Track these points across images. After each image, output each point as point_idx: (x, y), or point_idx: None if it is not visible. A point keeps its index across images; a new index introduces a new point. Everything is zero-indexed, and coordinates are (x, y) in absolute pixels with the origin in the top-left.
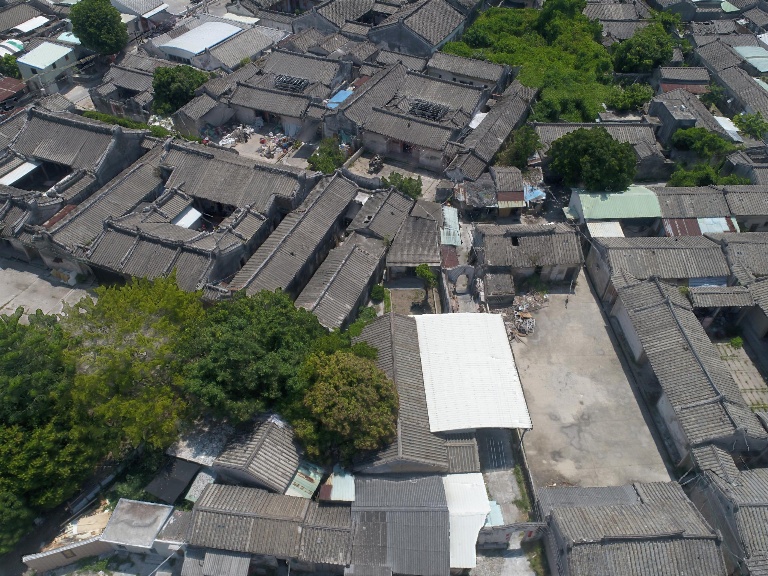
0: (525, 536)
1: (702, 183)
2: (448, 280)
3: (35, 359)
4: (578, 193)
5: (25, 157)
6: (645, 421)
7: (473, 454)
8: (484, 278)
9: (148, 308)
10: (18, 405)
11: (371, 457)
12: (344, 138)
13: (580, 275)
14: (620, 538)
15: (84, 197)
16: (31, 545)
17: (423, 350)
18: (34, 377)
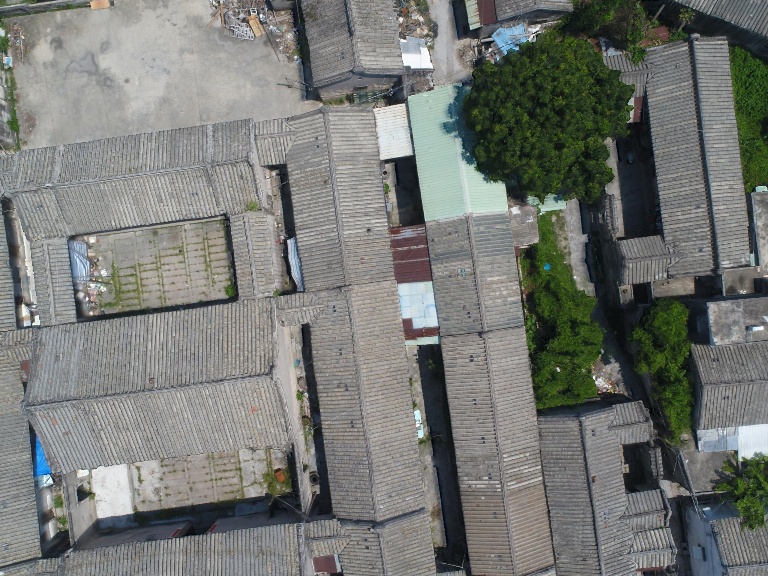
0: None
1: (554, 332)
2: None
3: None
4: None
5: None
6: None
7: None
8: None
9: None
10: None
11: None
12: None
13: None
14: None
15: None
16: None
17: None
18: None
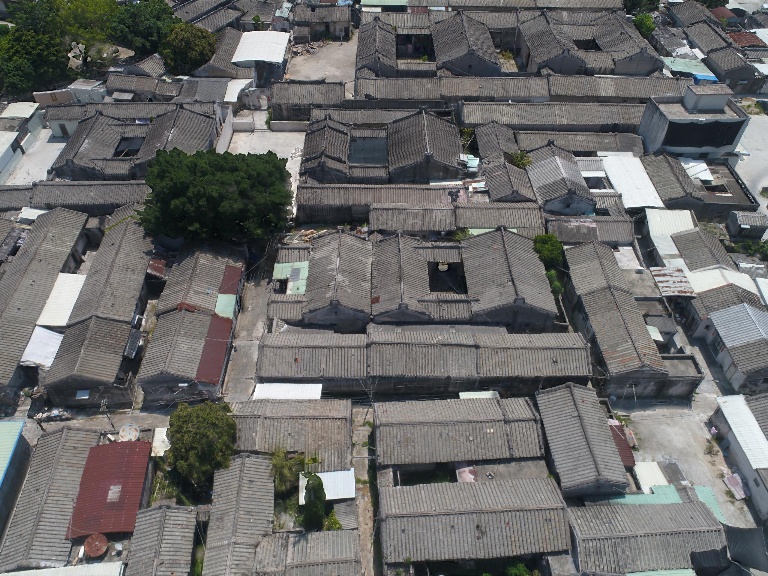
0: None
1: None
2: (274, 30)
3: (41, 4)
4: None
5: None
6: None
7: (250, 72)
8: (293, 28)
9: None
10: None
11: None
12: None
13: (356, 36)
14: (296, 81)
15: None
16: None
17: (241, 41)
18: (40, 8)
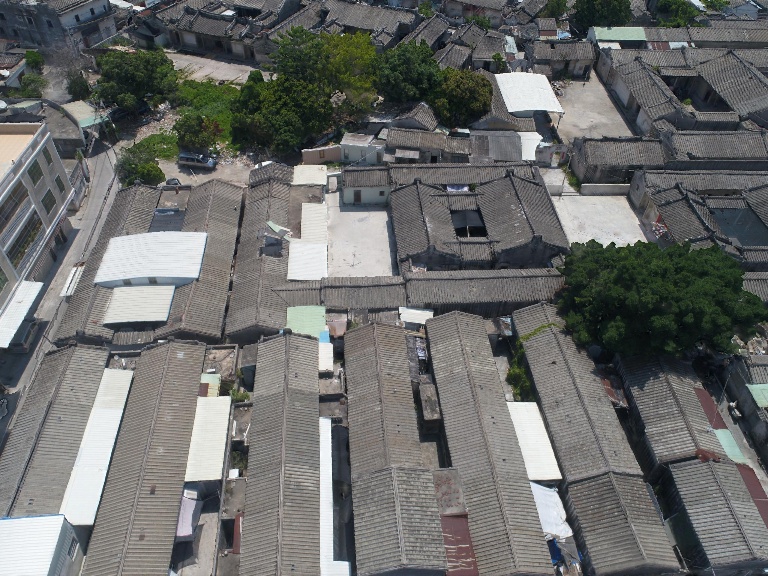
0: (560, 158)
1: None
2: None
3: None
4: (593, 26)
5: (228, 6)
6: (629, 129)
7: (532, 123)
8: (533, 67)
9: (357, 40)
10: (299, 74)
11: (477, 119)
12: (433, 6)
13: (593, 74)
14: (610, 138)
15: (271, 28)
16: (296, 158)
17: (501, 86)
18: (313, 54)
